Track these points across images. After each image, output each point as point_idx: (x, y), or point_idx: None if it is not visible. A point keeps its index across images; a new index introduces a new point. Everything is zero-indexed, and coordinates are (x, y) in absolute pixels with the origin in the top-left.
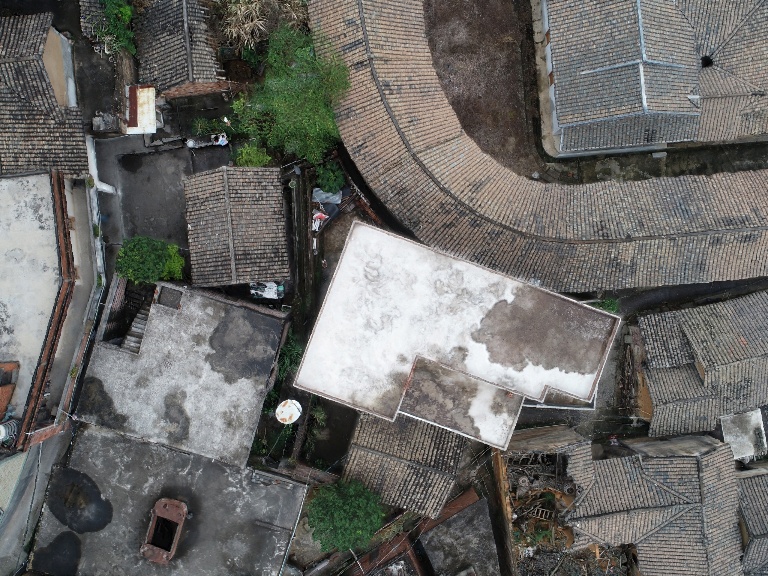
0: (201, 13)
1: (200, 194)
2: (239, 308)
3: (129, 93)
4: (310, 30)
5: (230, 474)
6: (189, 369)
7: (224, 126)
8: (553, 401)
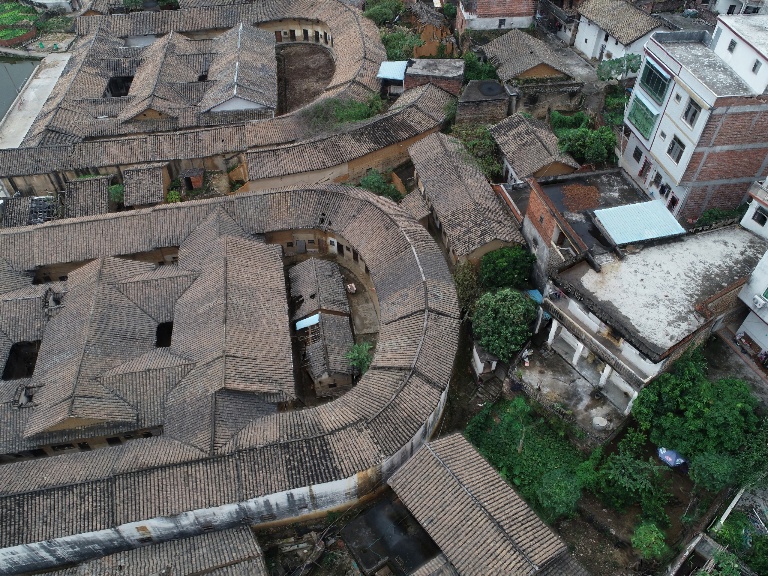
0: None
1: None
2: None
3: None
4: None
5: None
6: None
7: None
8: None
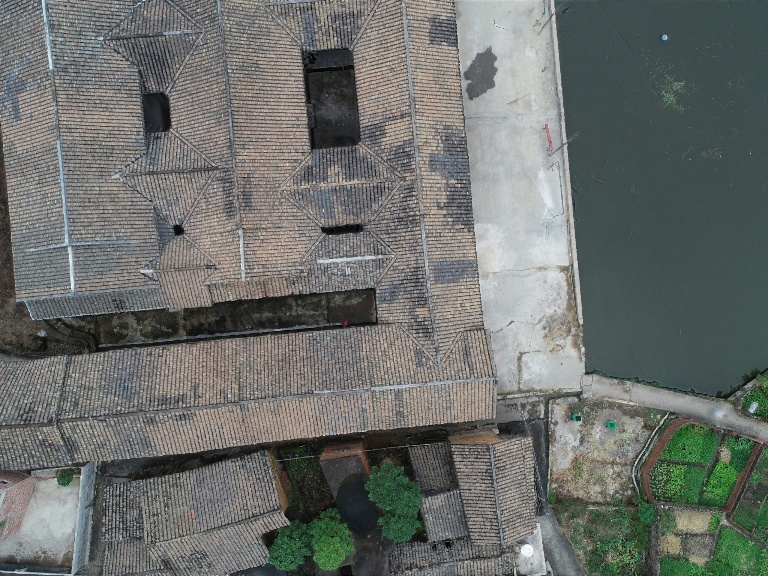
0: None
1: None
2: None
3: None
4: None
5: None
6: None
7: None
8: (41, 563)
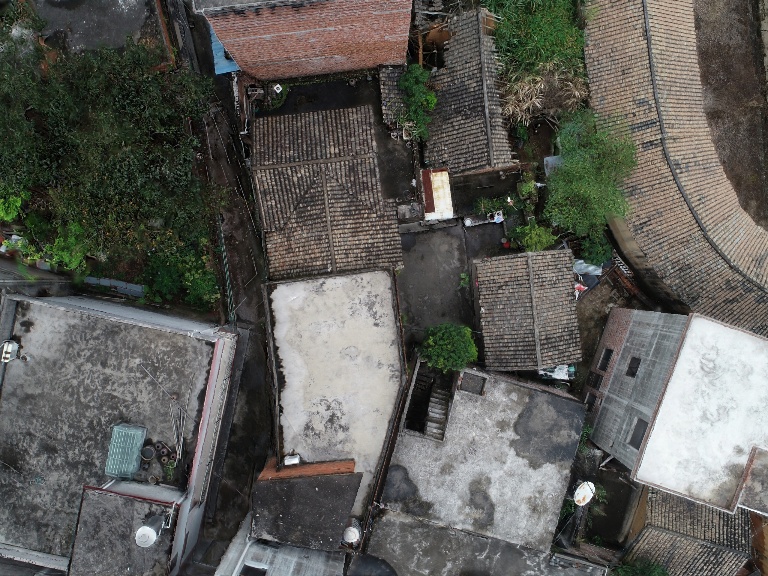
0: (497, 97)
1: (497, 278)
2: (543, 393)
3: (422, 177)
4: (591, 108)
5: (528, 557)
6: (494, 455)
7: (507, 206)
8: None
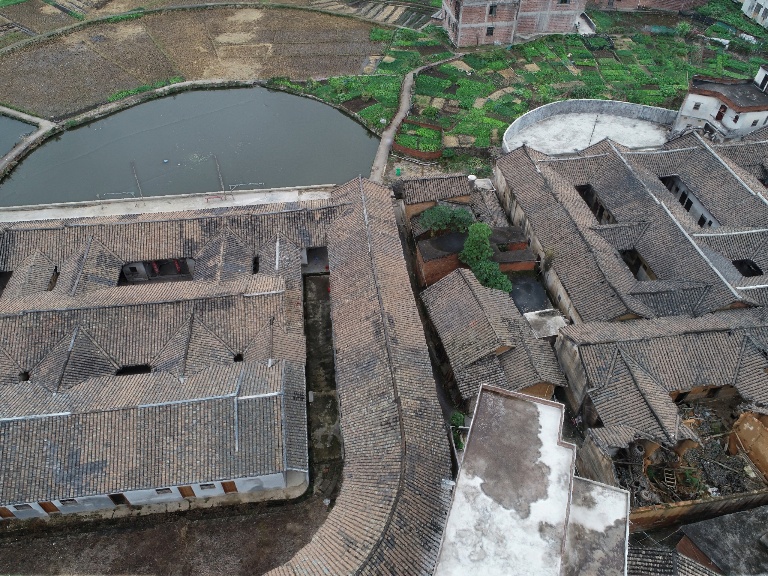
0: None
1: None
2: None
3: None
4: None
5: None
6: None
7: None
8: None
